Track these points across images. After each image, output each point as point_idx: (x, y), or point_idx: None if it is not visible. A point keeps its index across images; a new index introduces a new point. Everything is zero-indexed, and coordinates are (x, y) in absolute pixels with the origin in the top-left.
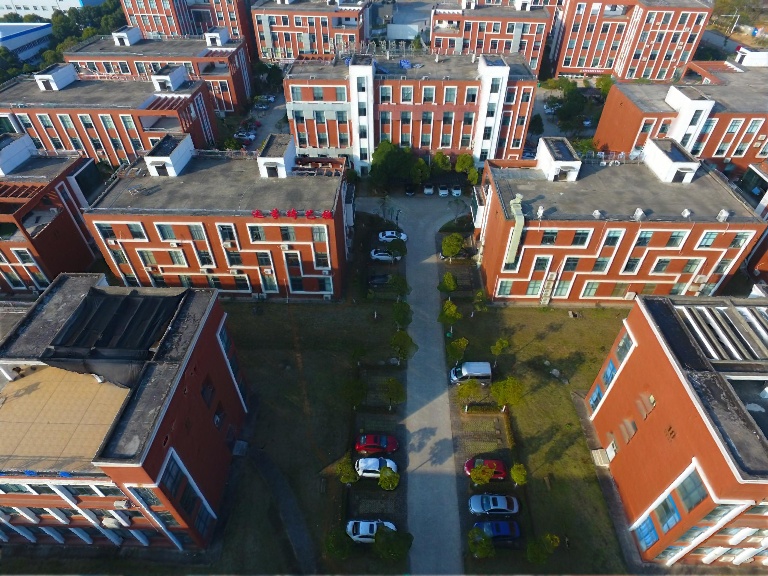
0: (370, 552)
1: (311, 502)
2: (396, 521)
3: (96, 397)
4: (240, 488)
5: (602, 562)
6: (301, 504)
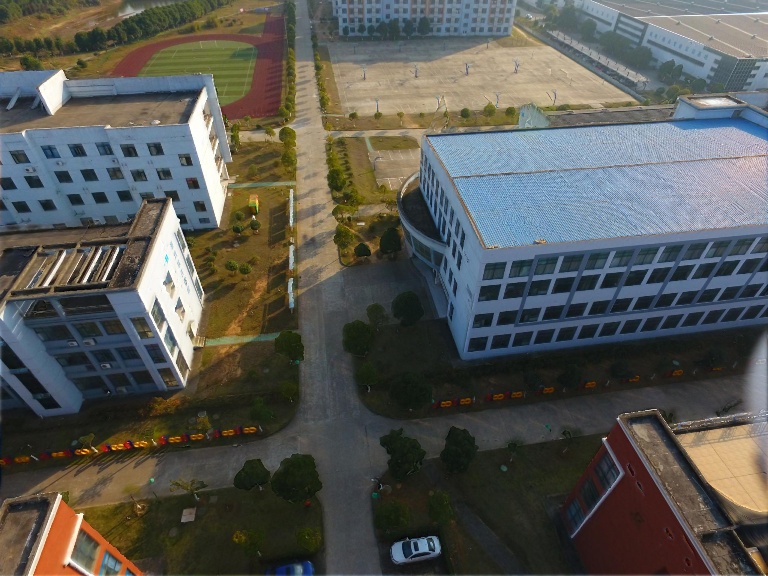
0: (413, 531)
1: (488, 572)
2: (394, 571)
3: (759, 511)
4: (571, 575)
5: (188, 568)
6: (497, 568)
